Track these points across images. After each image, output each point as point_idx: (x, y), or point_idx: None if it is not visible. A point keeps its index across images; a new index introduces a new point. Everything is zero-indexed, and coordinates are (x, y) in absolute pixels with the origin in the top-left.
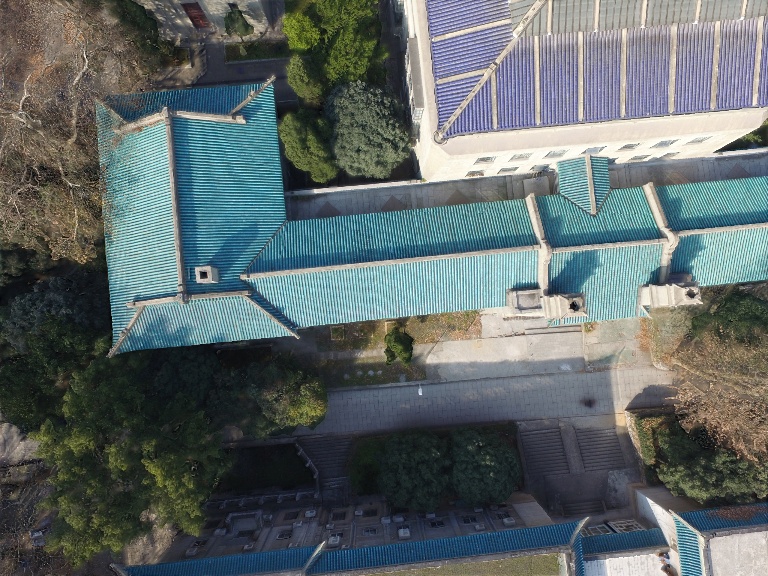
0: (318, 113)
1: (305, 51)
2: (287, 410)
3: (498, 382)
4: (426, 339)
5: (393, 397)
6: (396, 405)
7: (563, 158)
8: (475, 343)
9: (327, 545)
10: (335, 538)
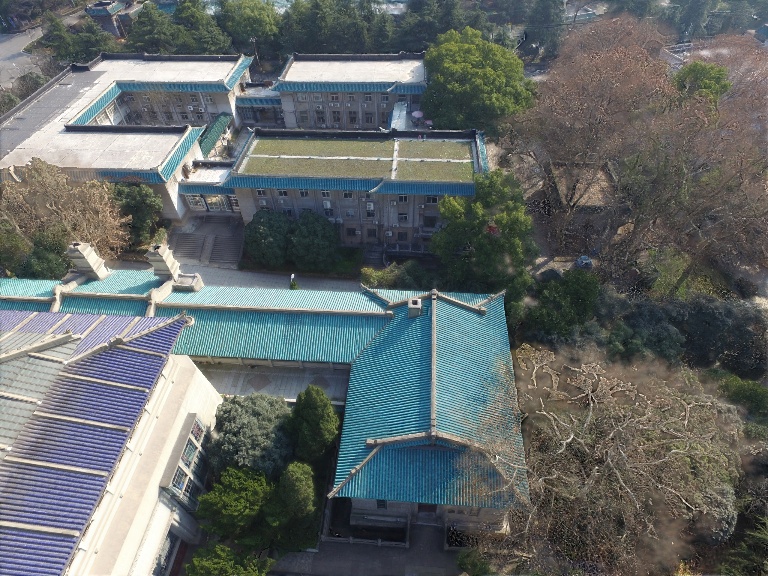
0: (295, 452)
1: None
2: None
3: None
4: None
5: None
6: None
7: None
8: None
9: (374, 203)
10: (369, 207)
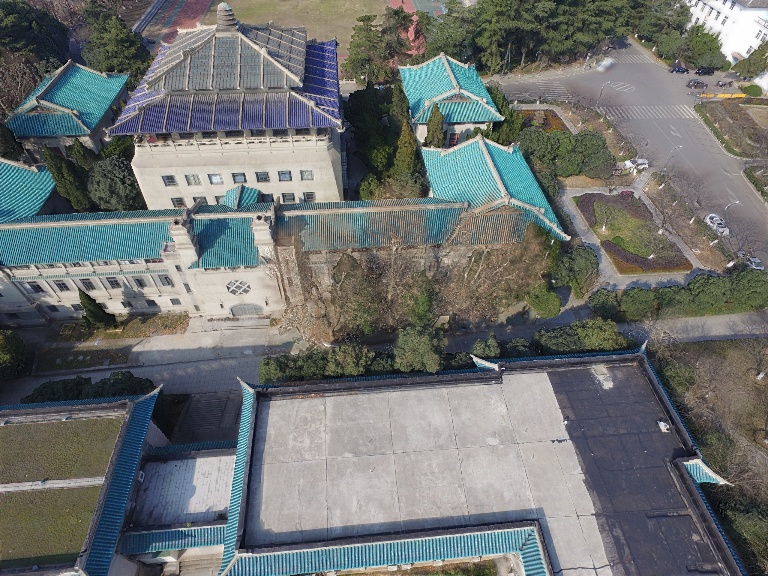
0: None
1: None
2: None
3: (188, 365)
4: (140, 335)
5: (92, 380)
6: None
7: (227, 187)
8: (178, 336)
9: None
10: None
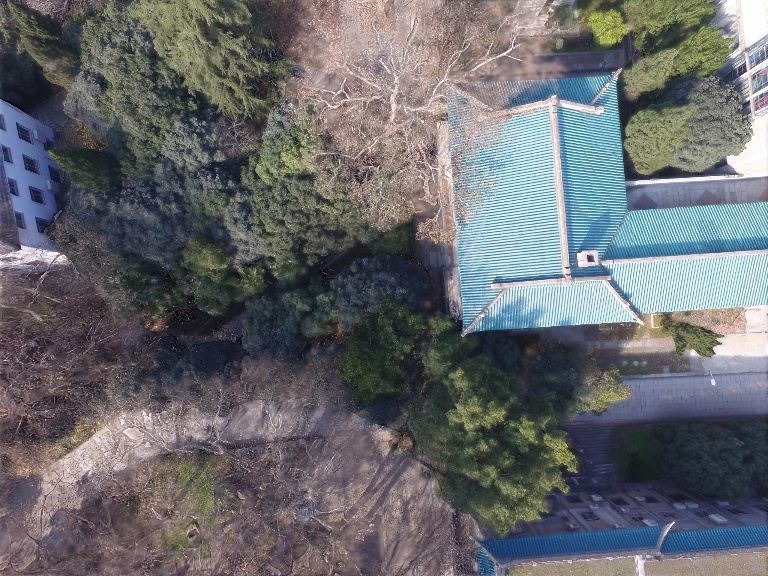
0: None
1: (609, 46)
2: (597, 395)
3: (761, 376)
4: None
5: (655, 388)
6: (658, 395)
7: None
8: (740, 337)
9: None
10: (651, 521)
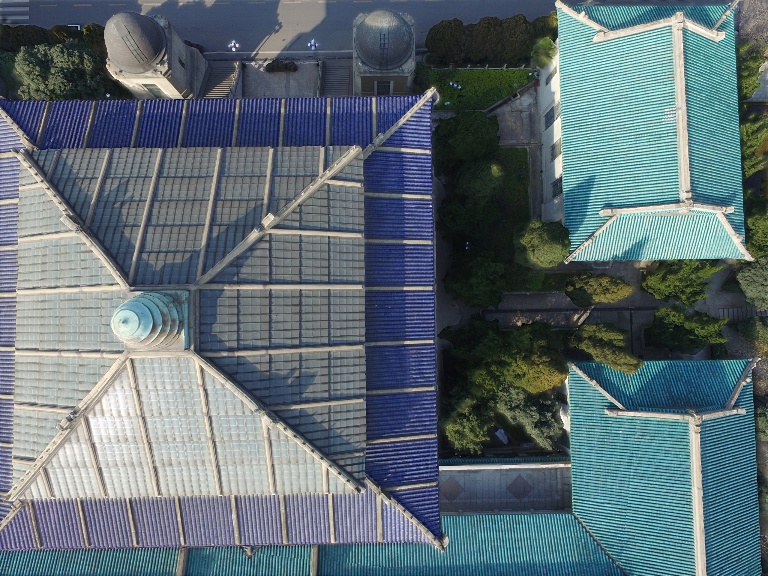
0: None
1: None
2: None
3: None
4: None
5: None
6: None
7: None
8: None
9: None
10: None
